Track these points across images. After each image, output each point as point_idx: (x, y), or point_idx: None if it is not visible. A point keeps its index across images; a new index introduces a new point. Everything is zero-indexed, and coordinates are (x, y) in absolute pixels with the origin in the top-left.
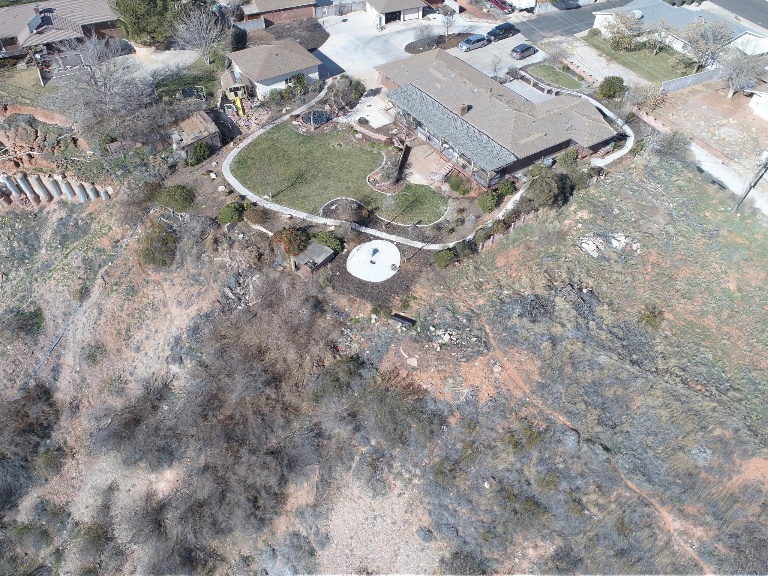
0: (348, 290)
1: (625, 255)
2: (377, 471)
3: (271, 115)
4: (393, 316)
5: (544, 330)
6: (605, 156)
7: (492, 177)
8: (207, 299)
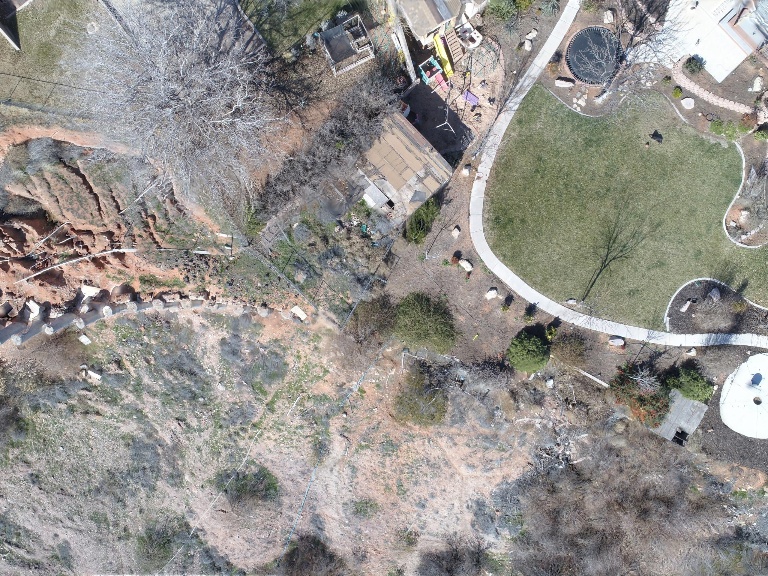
0: (729, 455)
1: None
2: None
3: (506, 64)
4: None
5: None
6: None
7: None
8: (514, 465)
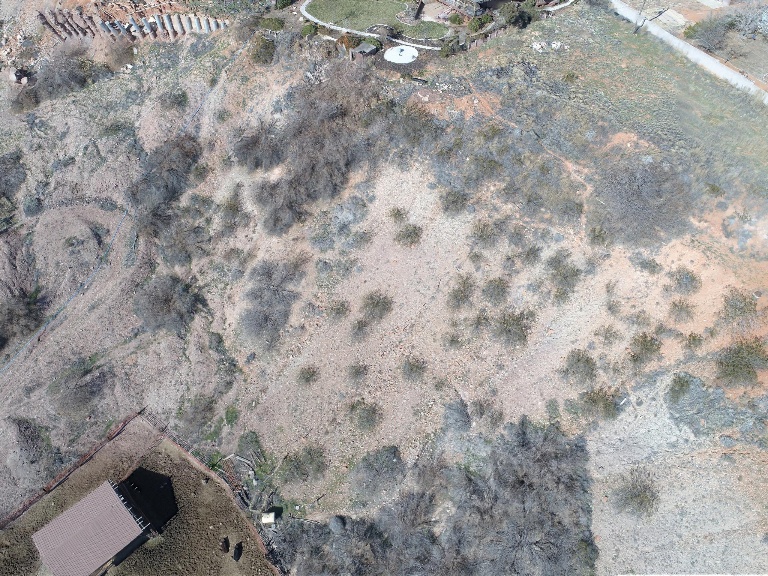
0: (385, 68)
1: (559, 51)
2: (403, 159)
3: None
4: (414, 78)
5: (505, 81)
6: (554, 6)
7: (477, 9)
8: (296, 78)
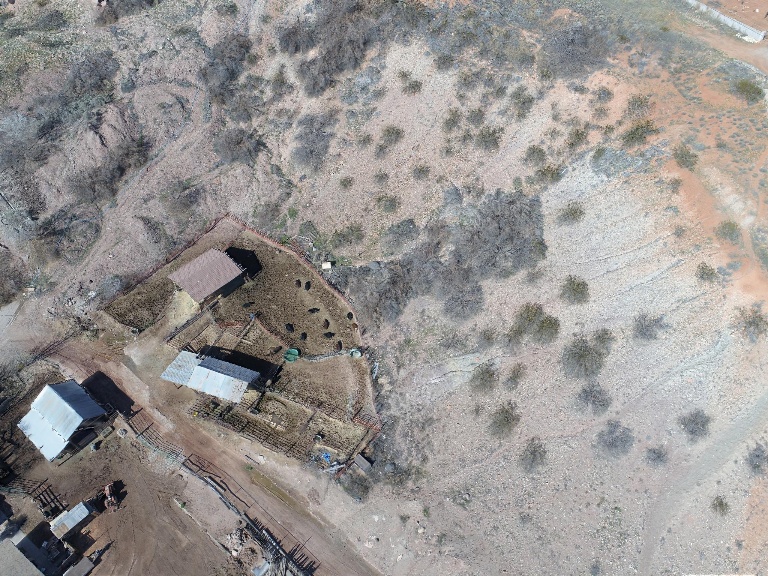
0: None
1: None
2: (406, 38)
3: None
4: None
5: None
6: None
7: None
8: None
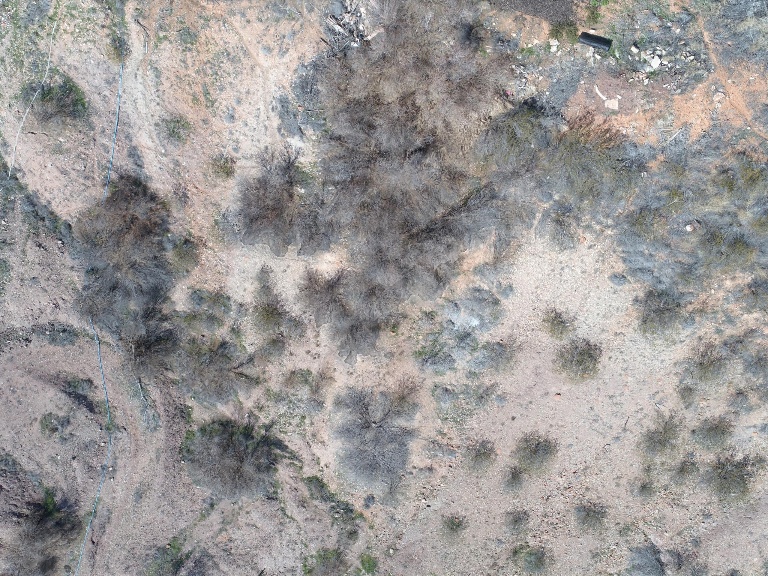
0: (512, 3)
1: None
2: (564, 227)
3: None
4: (581, 38)
5: None
6: None
7: None
8: (307, 40)
